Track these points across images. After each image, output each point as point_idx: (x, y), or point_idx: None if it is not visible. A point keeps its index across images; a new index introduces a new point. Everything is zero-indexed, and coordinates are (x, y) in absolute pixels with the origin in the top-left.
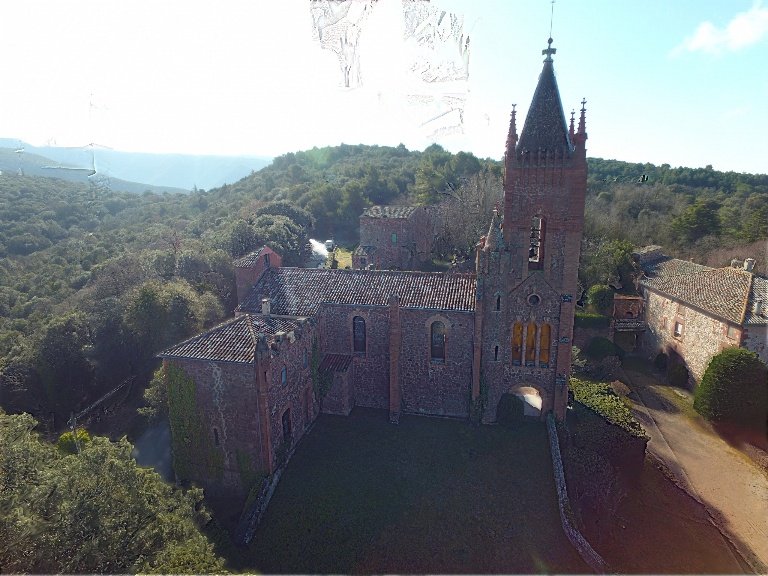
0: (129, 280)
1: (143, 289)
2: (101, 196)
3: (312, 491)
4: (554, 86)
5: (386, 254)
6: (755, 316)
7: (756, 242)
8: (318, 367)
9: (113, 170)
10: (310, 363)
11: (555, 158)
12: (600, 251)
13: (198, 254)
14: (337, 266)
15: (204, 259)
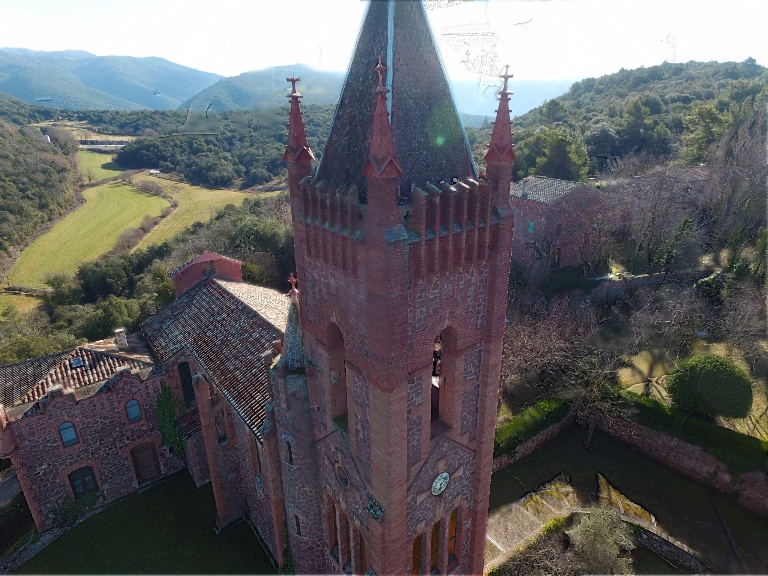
0: (198, 249)
1: (155, 269)
2: (268, 152)
3: (51, 575)
4: (387, 19)
5: (520, 247)
6: None
7: None
8: (176, 419)
9: (279, 127)
10: (153, 415)
11: None
12: None
13: (282, 226)
14: None
15: (275, 234)
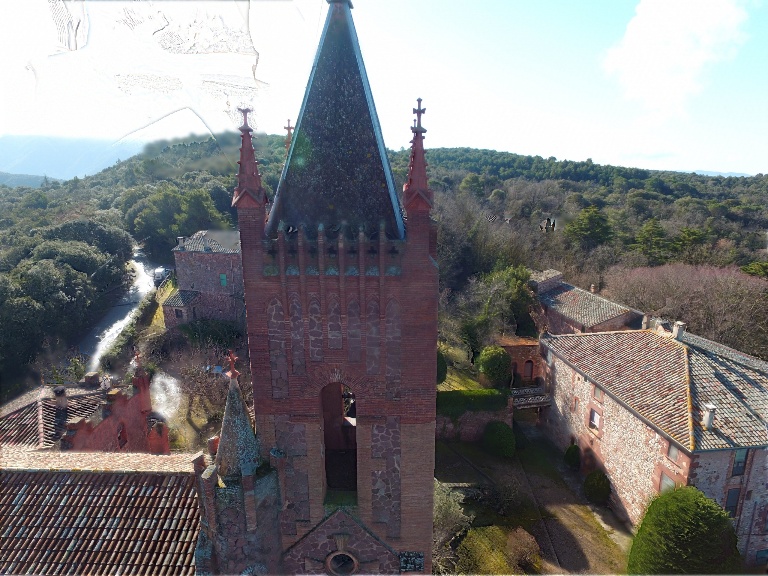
0: None
1: None
2: None
3: None
4: (357, 65)
5: (214, 301)
6: (707, 433)
7: (660, 267)
8: None
9: None
10: None
11: (360, 253)
12: (492, 295)
13: None
14: (154, 314)
15: None
